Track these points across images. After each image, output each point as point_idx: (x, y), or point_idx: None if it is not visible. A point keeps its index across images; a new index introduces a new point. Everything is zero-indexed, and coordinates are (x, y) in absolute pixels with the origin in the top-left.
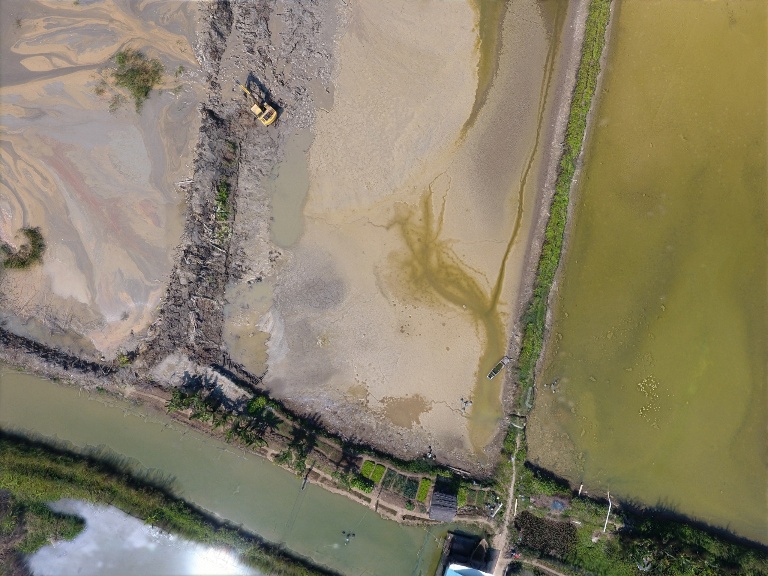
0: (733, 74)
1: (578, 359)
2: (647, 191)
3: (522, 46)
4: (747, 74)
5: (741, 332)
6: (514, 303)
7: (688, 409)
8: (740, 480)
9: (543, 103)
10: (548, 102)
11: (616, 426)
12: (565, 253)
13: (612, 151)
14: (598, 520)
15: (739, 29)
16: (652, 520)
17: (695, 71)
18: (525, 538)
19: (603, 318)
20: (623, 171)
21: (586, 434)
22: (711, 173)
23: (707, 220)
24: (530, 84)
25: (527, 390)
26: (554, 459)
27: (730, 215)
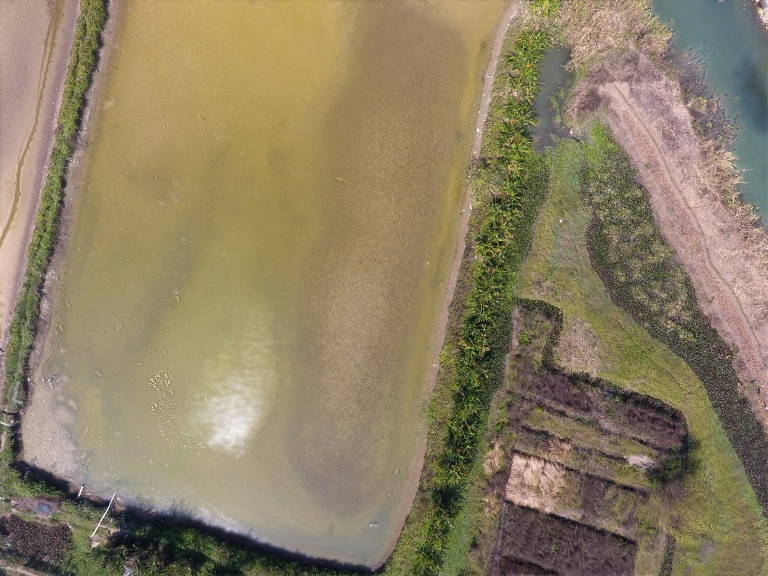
0: (256, 51)
1: (82, 352)
2: (160, 174)
3: (19, 18)
4: (272, 51)
5: (266, 325)
6: (10, 292)
7: (206, 406)
8: (265, 482)
9: (43, 79)
10: (49, 78)
11: (125, 424)
12: (66, 239)
13: (120, 131)
14: (90, 524)
15: (263, 4)
16: (154, 524)
17: (214, 48)
18: (15, 543)
19: (110, 309)
20: (133, 153)
21: (90, 432)
22: (232, 156)
23: (228, 206)
24: (28, 59)
25: (14, 385)
26: (53, 459)
27: (254, 201)
